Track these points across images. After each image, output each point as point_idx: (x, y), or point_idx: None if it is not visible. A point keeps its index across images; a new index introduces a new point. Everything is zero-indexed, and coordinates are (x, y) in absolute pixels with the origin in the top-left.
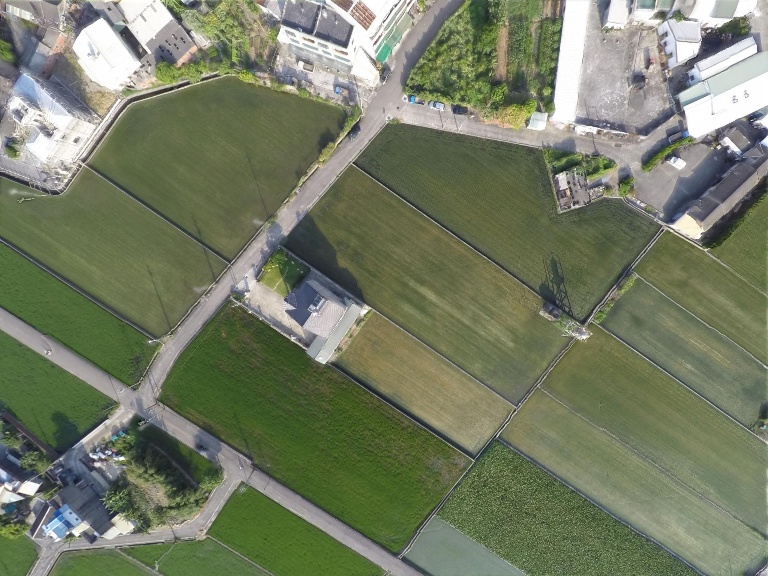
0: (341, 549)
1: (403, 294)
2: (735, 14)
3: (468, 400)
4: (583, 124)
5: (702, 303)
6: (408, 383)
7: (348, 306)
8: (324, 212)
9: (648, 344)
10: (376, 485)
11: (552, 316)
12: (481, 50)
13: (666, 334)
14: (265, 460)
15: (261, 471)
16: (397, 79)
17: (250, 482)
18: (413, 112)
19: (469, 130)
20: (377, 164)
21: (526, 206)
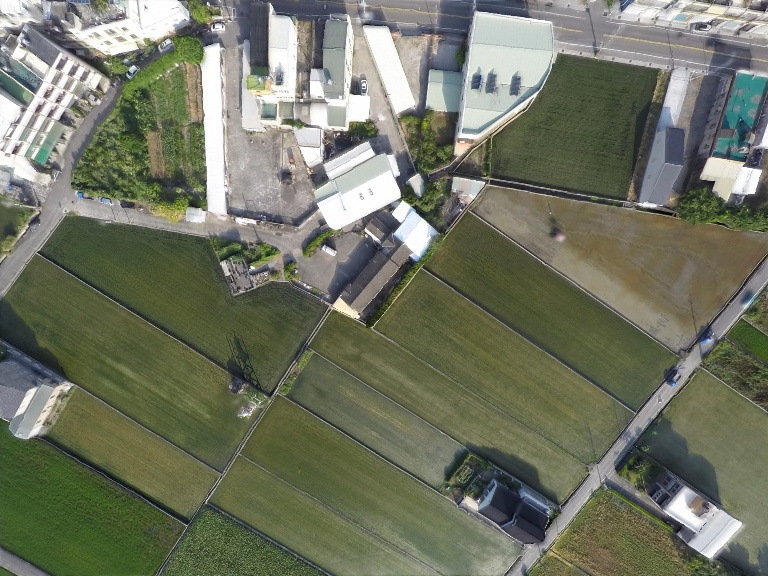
0: None
1: (101, 371)
2: (358, 120)
3: (177, 468)
4: (243, 215)
5: (376, 375)
6: (119, 453)
7: (39, 386)
8: (18, 297)
9: (334, 413)
10: (99, 551)
11: None
12: None
13: (349, 404)
14: None
15: None
16: (68, 176)
17: None
18: (87, 206)
19: (141, 221)
20: (61, 252)
21: (203, 289)
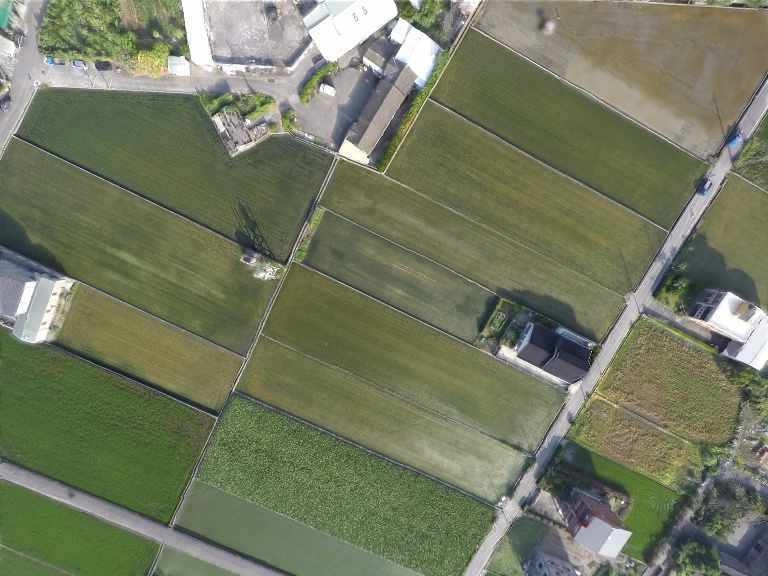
0: (111, 527)
1: (103, 261)
2: None
3: (198, 358)
4: (230, 63)
5: (394, 227)
6: (135, 351)
7: (38, 280)
8: (0, 189)
9: (354, 275)
10: (129, 458)
11: (244, 260)
12: (104, 1)
13: (369, 263)
14: (13, 451)
15: (11, 462)
16: (33, 42)
17: (1, 475)
18: (59, 74)
19: (120, 85)
20: (40, 133)
21: (198, 154)
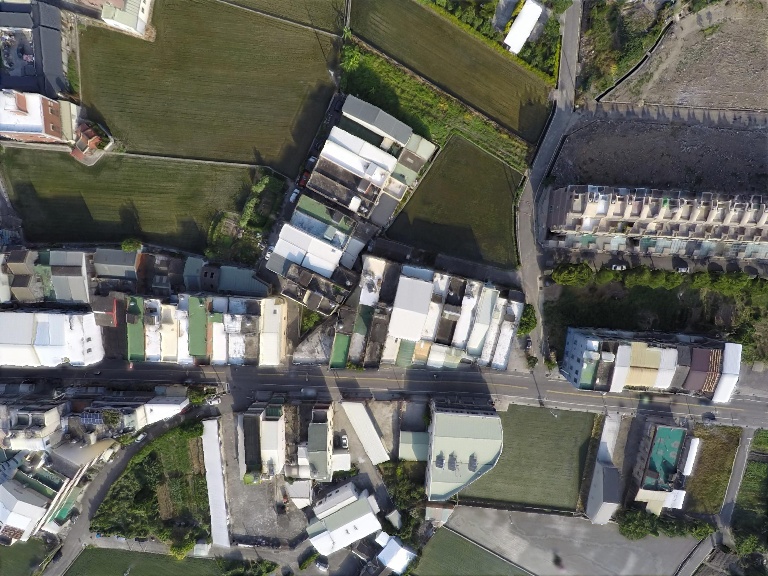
0: None
1: None
2: None
3: None
4: (245, 540)
5: None
6: None
7: None
8: None
9: None
10: None
11: None
12: None
13: None
14: None
15: None
16: (86, 518)
17: None
18: (104, 540)
19: (153, 549)
20: None
21: None
